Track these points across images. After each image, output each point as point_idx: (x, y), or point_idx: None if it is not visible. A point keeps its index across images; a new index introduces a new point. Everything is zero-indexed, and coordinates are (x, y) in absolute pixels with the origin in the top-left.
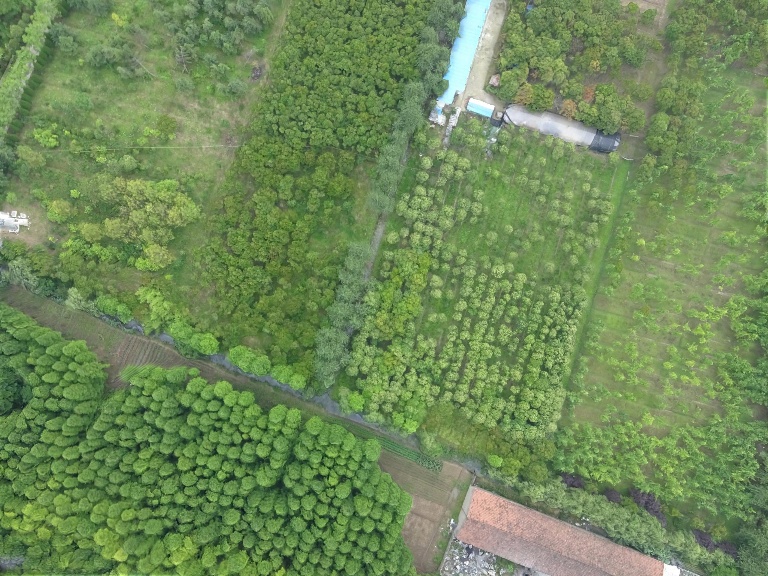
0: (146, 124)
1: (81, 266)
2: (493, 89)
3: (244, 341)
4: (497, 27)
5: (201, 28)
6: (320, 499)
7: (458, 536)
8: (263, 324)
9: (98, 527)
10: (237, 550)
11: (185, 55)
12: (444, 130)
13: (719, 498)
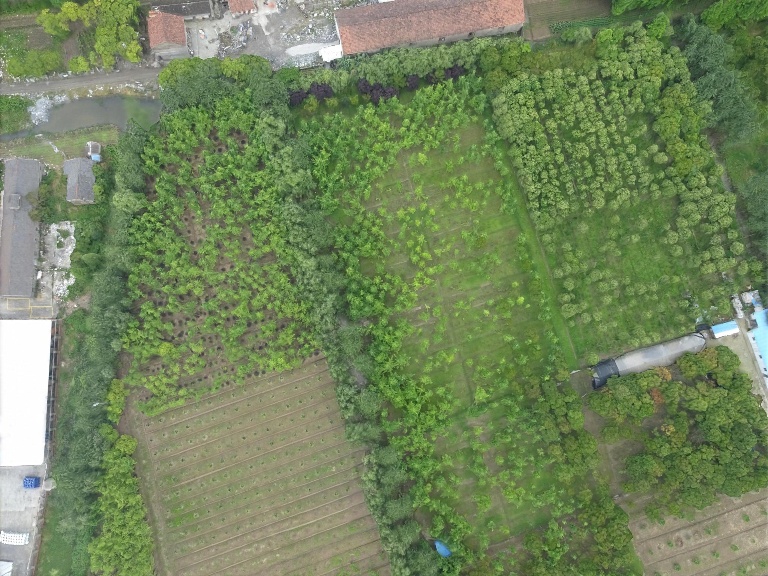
0: None
1: None
2: None
3: (759, 28)
4: None
5: None
6: None
7: None
8: None
9: None
10: None
11: None
12: None
13: None
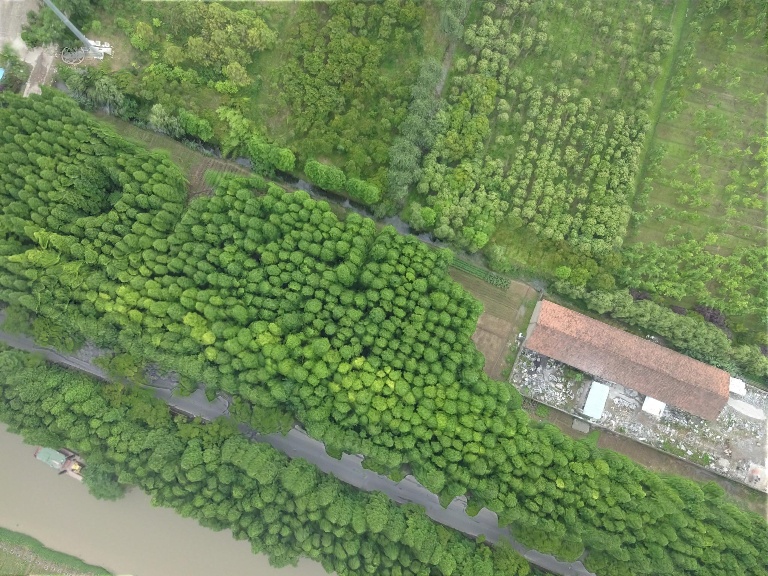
0: None
1: (164, 85)
2: None
3: None
4: None
5: None
6: (398, 292)
7: (528, 344)
8: (338, 141)
9: (187, 310)
10: (319, 337)
11: None
12: None
13: None
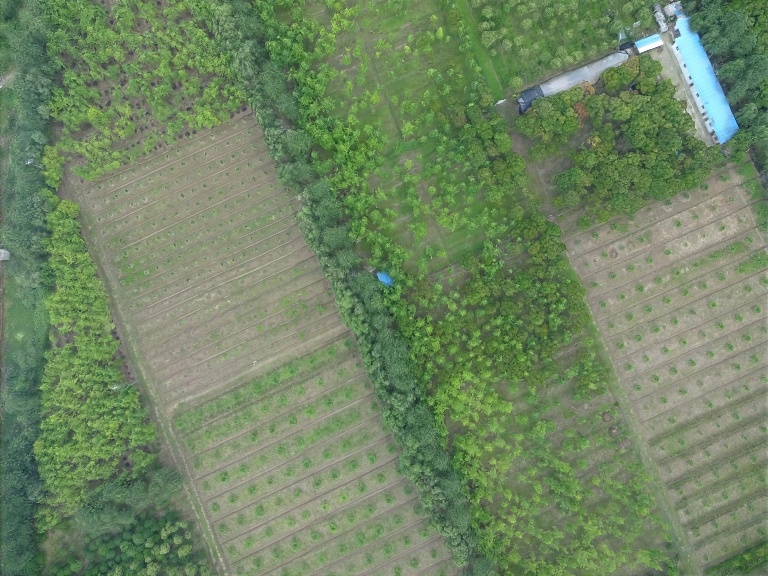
0: None
1: None
2: None
3: None
4: None
5: None
6: None
7: None
8: None
9: None
10: None
11: None
12: None
13: None
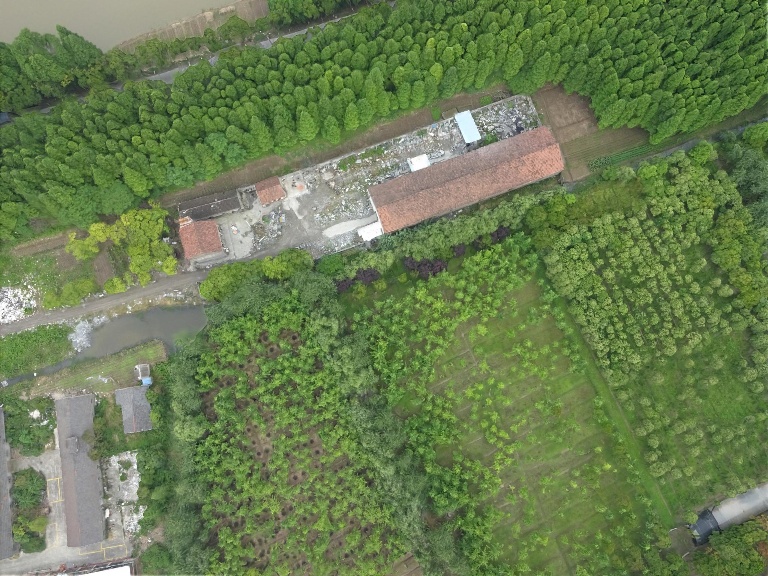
0: None
1: None
2: None
3: None
4: None
5: None
6: None
7: None
8: None
9: None
10: None
11: None
12: None
13: (381, 317)
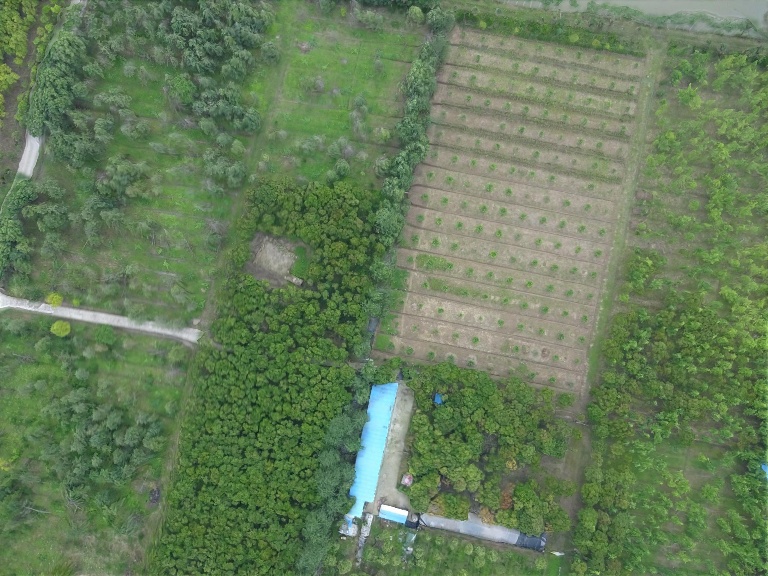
0: (42, 567)
1: None
2: (405, 491)
3: None
4: (406, 416)
5: (90, 464)
6: None
7: None
8: None
9: None
10: None
11: (74, 500)
12: (357, 538)
13: None
